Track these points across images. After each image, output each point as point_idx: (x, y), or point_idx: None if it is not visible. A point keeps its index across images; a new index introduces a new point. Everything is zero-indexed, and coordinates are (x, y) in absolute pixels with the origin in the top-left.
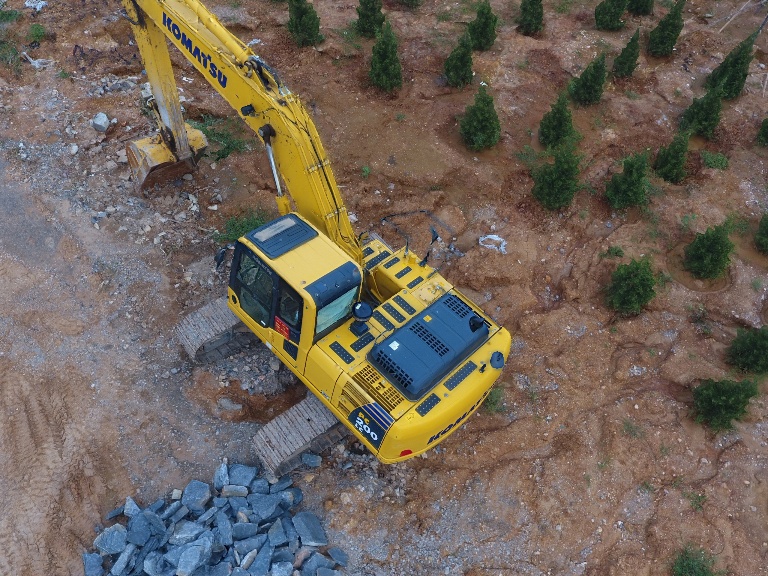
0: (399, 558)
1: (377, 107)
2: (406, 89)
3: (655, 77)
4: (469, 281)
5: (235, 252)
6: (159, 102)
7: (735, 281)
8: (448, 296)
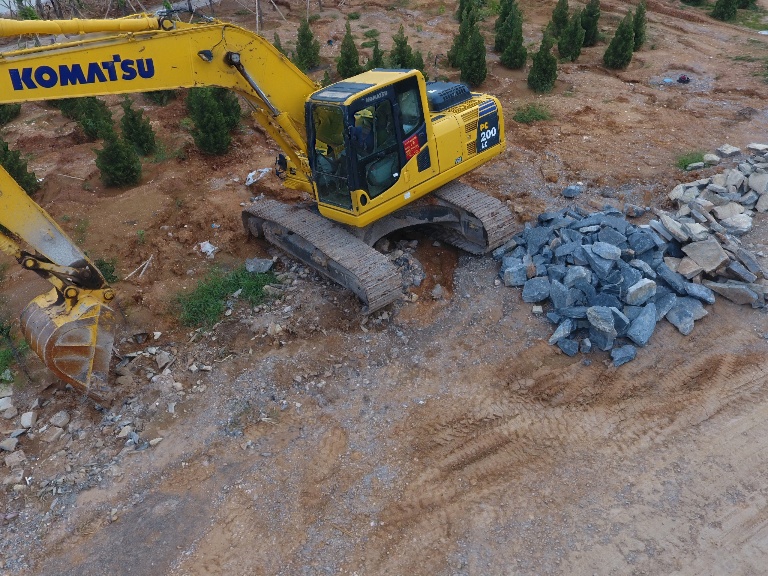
0: None
1: None
2: None
3: None
4: None
5: None
6: (41, 243)
7: None
8: None
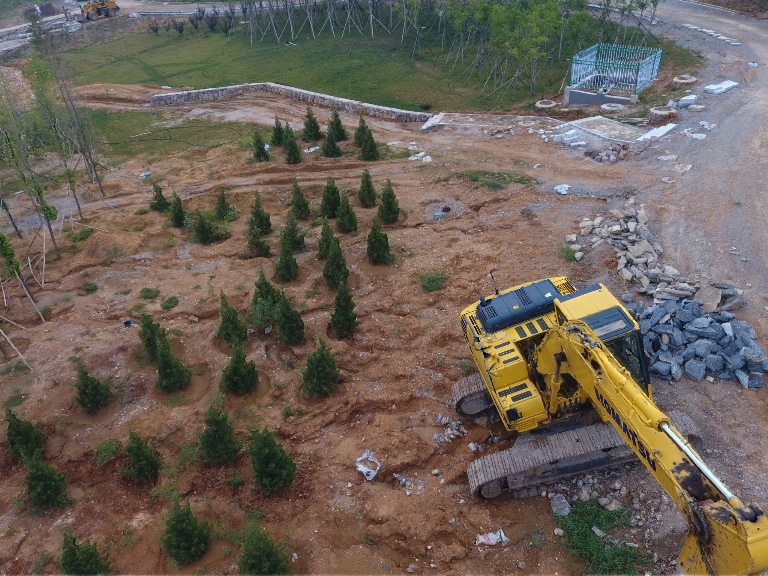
0: None
1: None
2: None
3: None
4: (419, 438)
5: None
6: None
7: None
8: (491, 322)
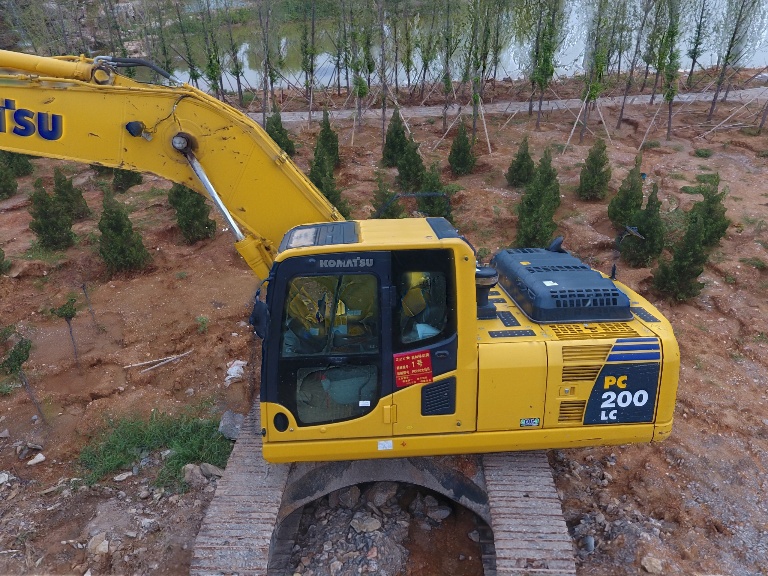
0: (764, 575)
1: (145, 281)
2: (158, 259)
3: (350, 174)
4: None
5: (271, 299)
6: None
7: (567, 226)
8: None
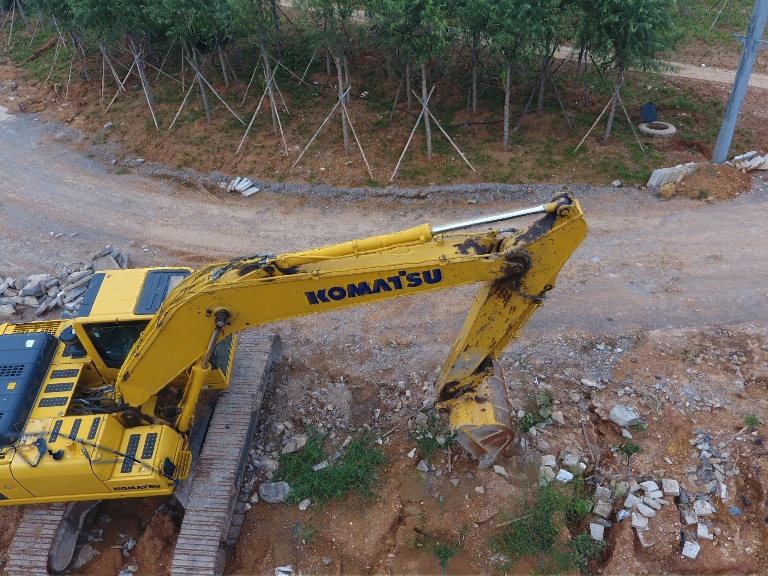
0: None
1: None
2: None
3: None
4: None
5: None
6: None
7: None
8: (4, 427)
